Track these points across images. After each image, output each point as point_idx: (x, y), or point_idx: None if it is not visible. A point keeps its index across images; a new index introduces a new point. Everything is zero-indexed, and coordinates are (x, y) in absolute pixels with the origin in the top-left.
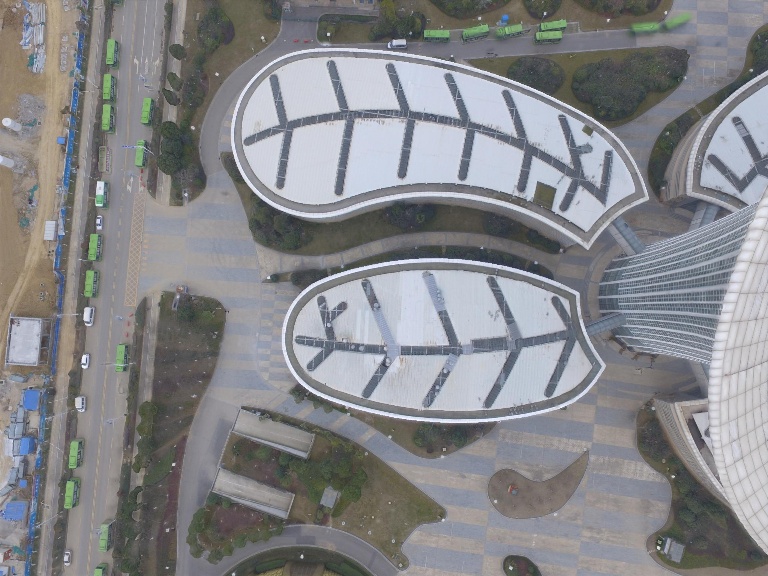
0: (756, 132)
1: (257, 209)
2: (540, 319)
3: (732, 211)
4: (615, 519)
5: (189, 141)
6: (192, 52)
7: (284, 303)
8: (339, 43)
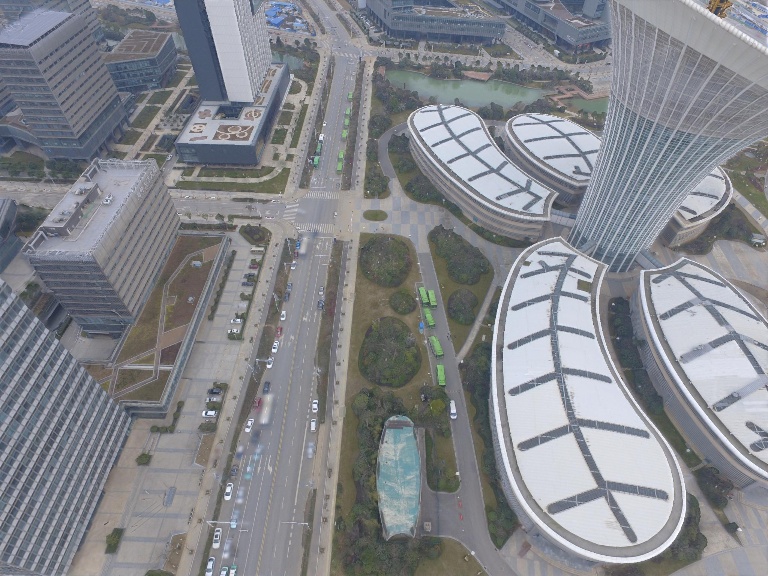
0: (505, 191)
1: (682, 539)
2: (676, 289)
3: None
4: (759, 266)
5: None
6: None
7: (749, 517)
8: (456, 468)
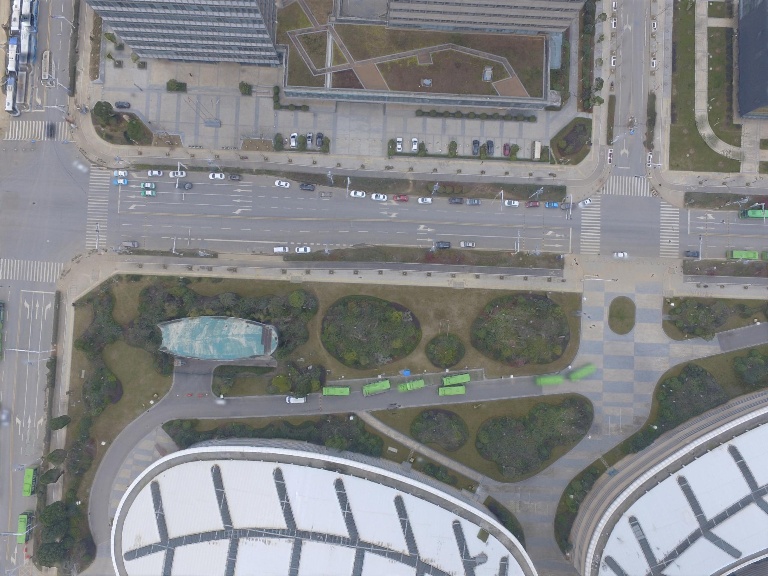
0: (652, 536)
1: None
2: None
3: None
4: None
5: (75, 514)
6: (78, 413)
7: None
8: (235, 396)
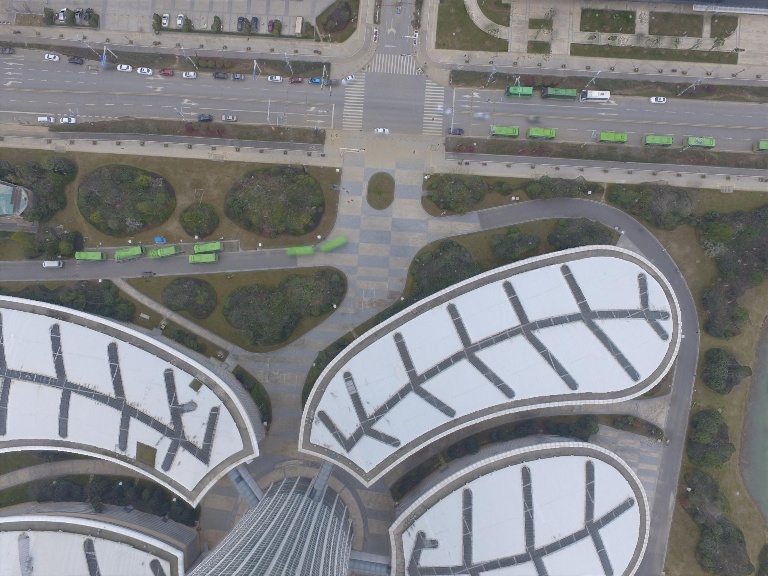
0: (363, 390)
1: None
2: None
3: (343, 468)
4: None
5: None
6: None
7: None
8: None
